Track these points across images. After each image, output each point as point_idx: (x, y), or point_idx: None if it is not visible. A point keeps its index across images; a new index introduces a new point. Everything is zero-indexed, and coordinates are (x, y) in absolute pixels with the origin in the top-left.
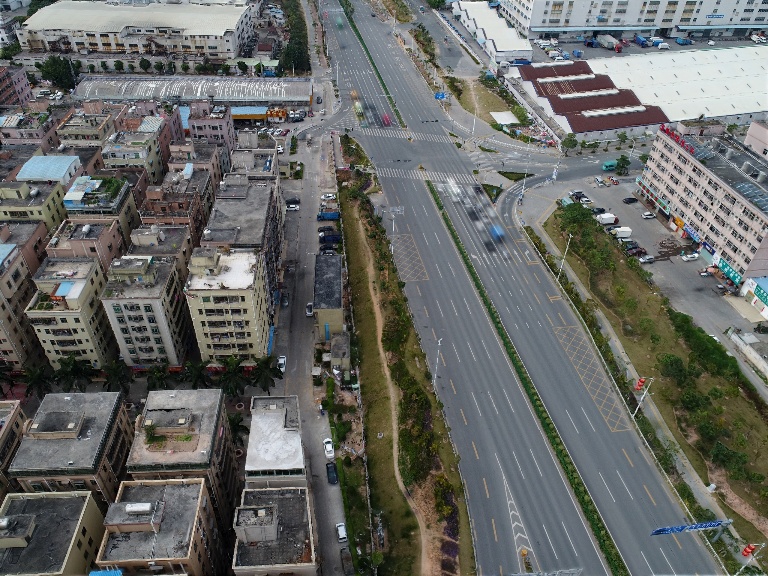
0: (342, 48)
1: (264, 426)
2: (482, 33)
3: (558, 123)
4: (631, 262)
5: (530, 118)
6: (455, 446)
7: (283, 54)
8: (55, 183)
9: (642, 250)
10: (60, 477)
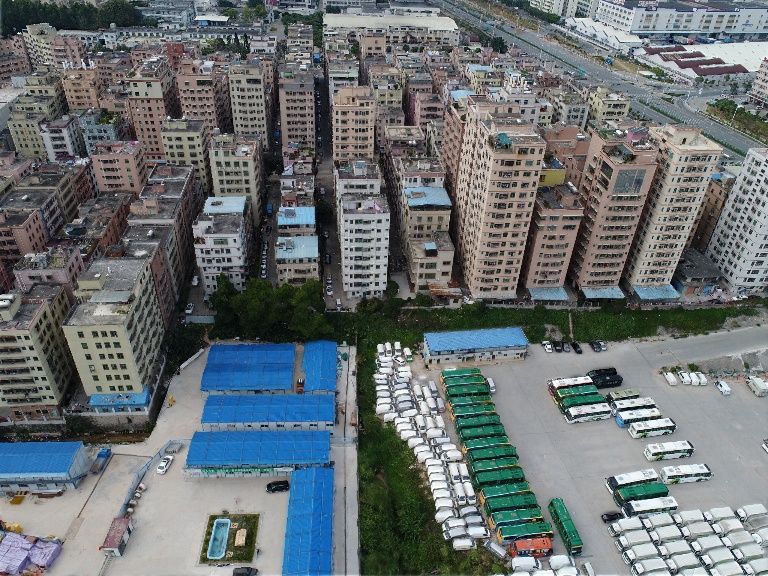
0: None
1: None
2: (603, 33)
3: (684, 73)
4: (767, 115)
5: (665, 72)
6: None
7: (491, 42)
8: (492, 73)
9: (764, 118)
10: None
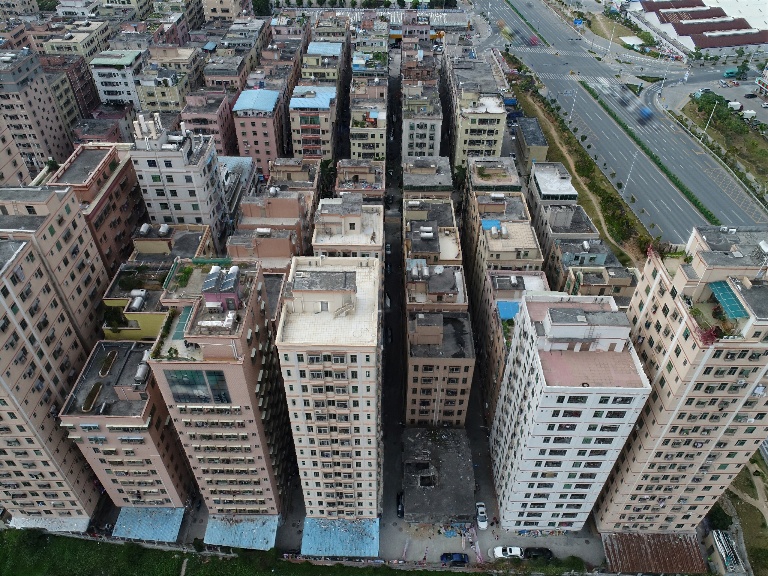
0: None
1: (545, 177)
2: None
3: (681, 43)
4: (761, 126)
5: (656, 40)
6: (645, 226)
7: None
8: (336, 57)
9: None
10: (430, 193)
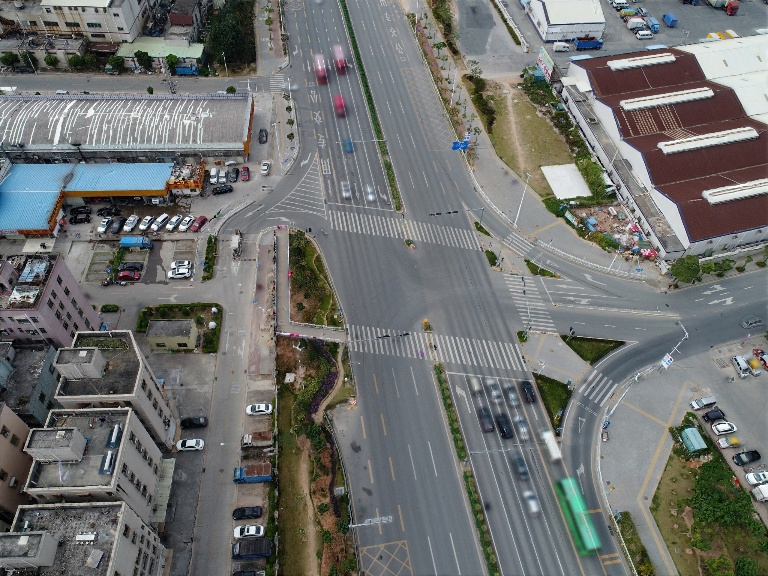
0: (308, 7)
1: None
2: None
3: (658, 206)
4: None
5: (610, 189)
6: None
7: (209, 37)
8: None
9: None
10: None
